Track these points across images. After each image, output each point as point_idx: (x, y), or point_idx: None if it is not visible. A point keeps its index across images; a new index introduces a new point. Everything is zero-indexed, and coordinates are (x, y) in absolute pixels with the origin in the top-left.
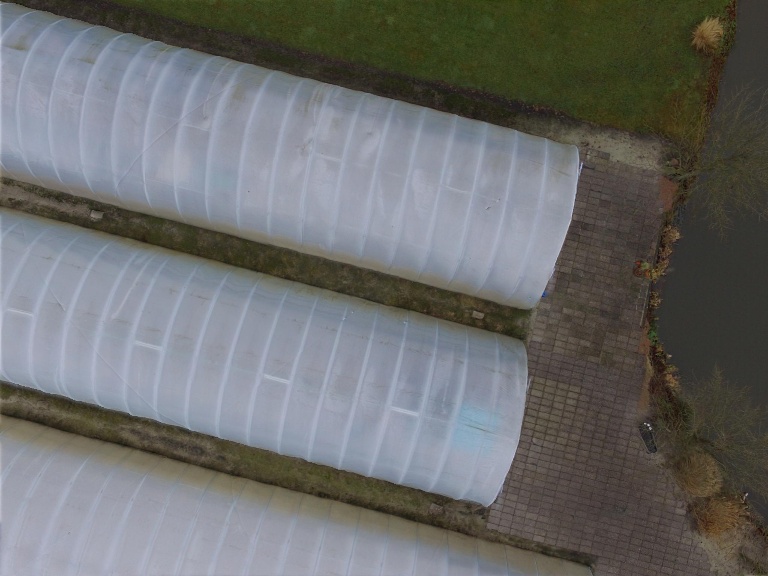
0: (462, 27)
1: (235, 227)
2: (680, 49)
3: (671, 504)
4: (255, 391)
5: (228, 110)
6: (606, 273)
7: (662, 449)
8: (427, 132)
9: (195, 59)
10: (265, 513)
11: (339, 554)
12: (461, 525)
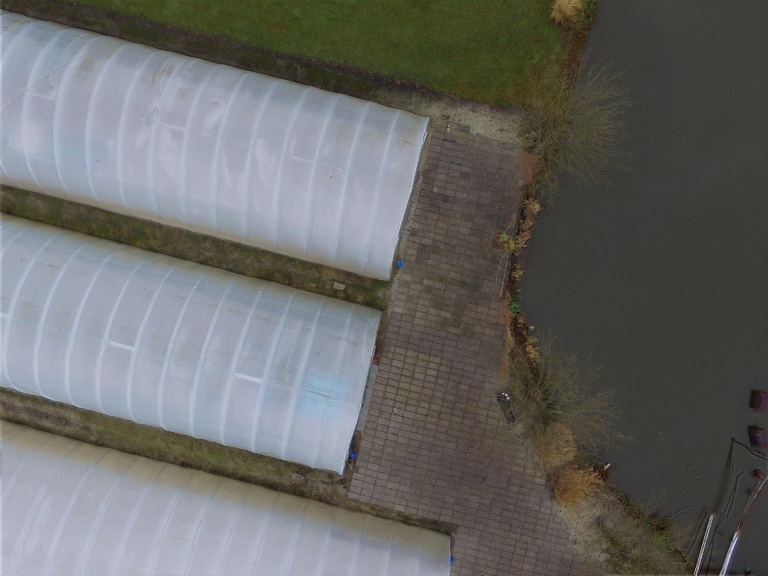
0: (324, 1)
1: (94, 198)
2: (540, 23)
3: (530, 473)
4: (100, 358)
5: (75, 79)
6: (466, 245)
7: (521, 419)
8: (274, 102)
9: (49, 30)
10: (119, 481)
11: (189, 520)
12: (323, 494)
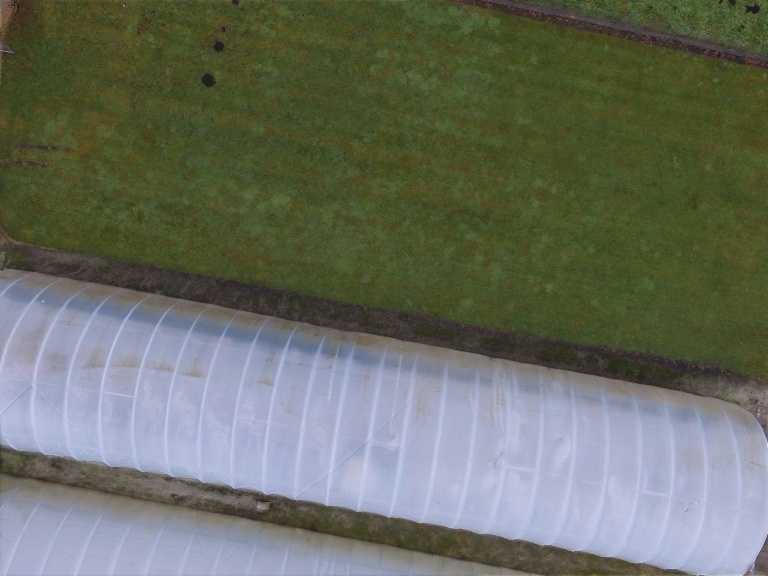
0: (622, 291)
1: (413, 520)
2: None
3: None
4: None
5: (415, 426)
6: None
7: None
8: (615, 430)
9: (368, 362)
10: None
11: None
12: None
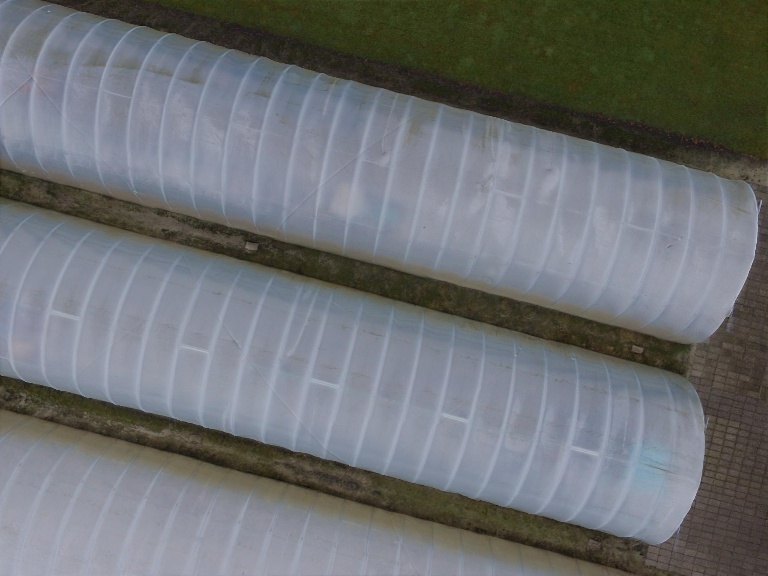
0: (621, 59)
1: (398, 261)
2: None
3: None
4: (433, 430)
5: (406, 146)
6: (766, 308)
7: None
8: (604, 168)
9: (365, 92)
10: (432, 551)
11: None
12: (619, 561)
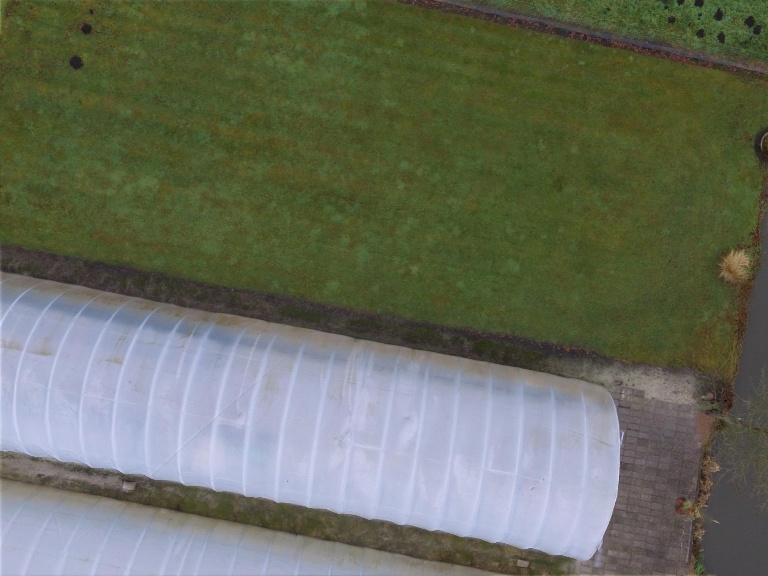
0: (487, 273)
1: (273, 500)
2: (707, 280)
3: None
4: None
5: (262, 404)
6: (649, 512)
7: None
8: (464, 409)
9: (223, 341)
10: None
11: None
12: None
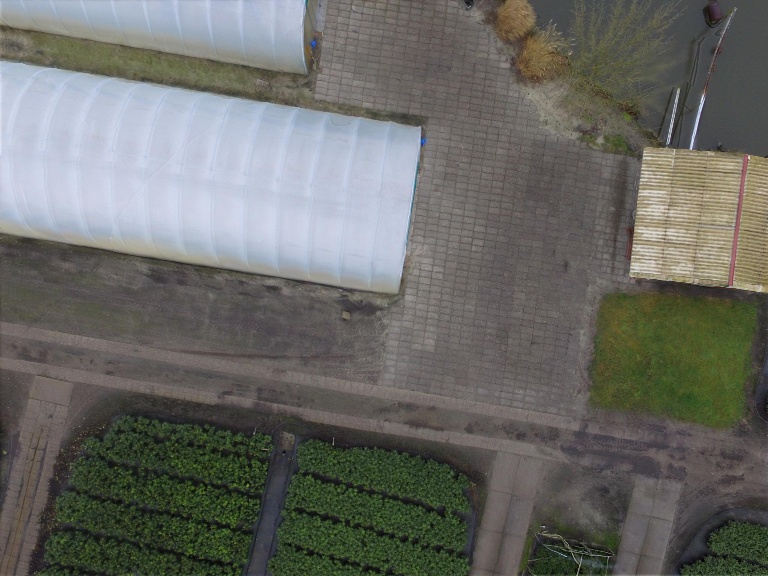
0: None
1: None
2: None
3: (495, 59)
4: None
5: None
6: None
7: (481, 5)
8: None
9: None
10: (76, 76)
11: (150, 98)
12: (289, 99)
